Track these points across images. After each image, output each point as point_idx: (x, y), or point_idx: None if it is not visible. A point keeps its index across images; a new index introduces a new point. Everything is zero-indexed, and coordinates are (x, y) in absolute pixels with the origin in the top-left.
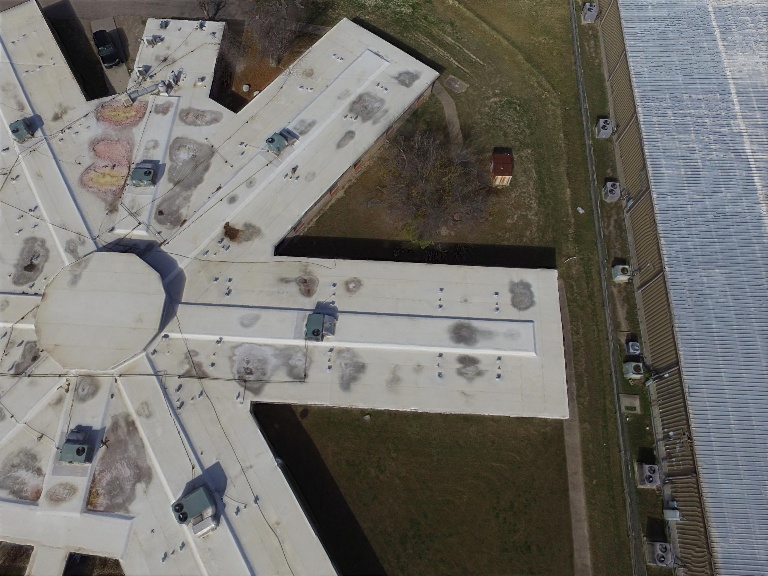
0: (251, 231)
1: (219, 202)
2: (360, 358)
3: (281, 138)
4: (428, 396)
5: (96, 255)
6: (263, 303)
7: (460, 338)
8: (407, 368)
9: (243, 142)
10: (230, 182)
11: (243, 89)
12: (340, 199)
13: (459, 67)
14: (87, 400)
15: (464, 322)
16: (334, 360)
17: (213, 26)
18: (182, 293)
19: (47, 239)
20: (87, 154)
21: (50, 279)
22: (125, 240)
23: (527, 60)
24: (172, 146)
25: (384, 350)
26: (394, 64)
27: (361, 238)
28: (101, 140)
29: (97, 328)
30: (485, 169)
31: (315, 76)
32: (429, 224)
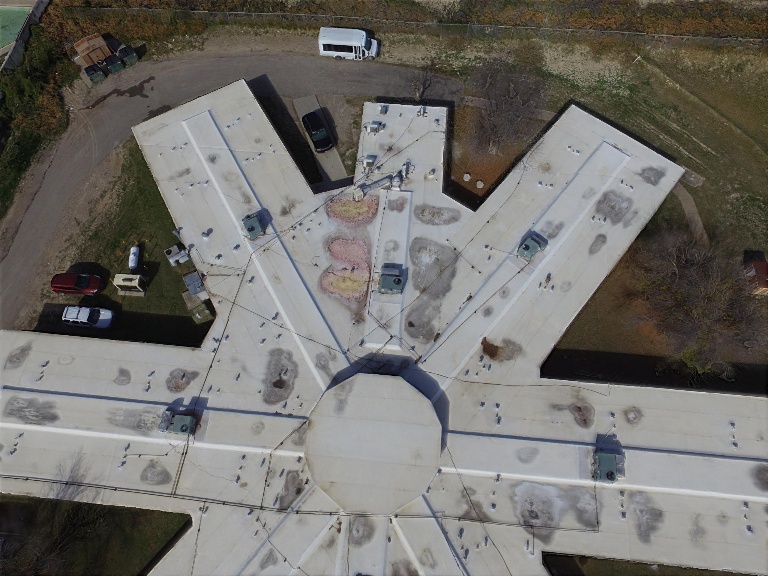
0: (511, 348)
1: (473, 314)
2: (656, 505)
3: (536, 245)
4: (741, 554)
5: (360, 377)
6: (538, 434)
7: (766, 485)
8: (711, 519)
9: (487, 245)
10: (481, 291)
11: (464, 178)
12: (586, 306)
13: (690, 157)
14: (364, 544)
15: (767, 466)
16: (627, 506)
17: (435, 112)
18: (448, 419)
19: (294, 351)
20: (323, 254)
21: (303, 398)
22: (378, 355)
23: (766, 152)
24: (412, 247)
25: (682, 496)
26: (635, 159)
27: (615, 352)
28: (335, 239)
29: (374, 464)
30: (738, 275)
31: (552, 171)
32: (716, 350)
